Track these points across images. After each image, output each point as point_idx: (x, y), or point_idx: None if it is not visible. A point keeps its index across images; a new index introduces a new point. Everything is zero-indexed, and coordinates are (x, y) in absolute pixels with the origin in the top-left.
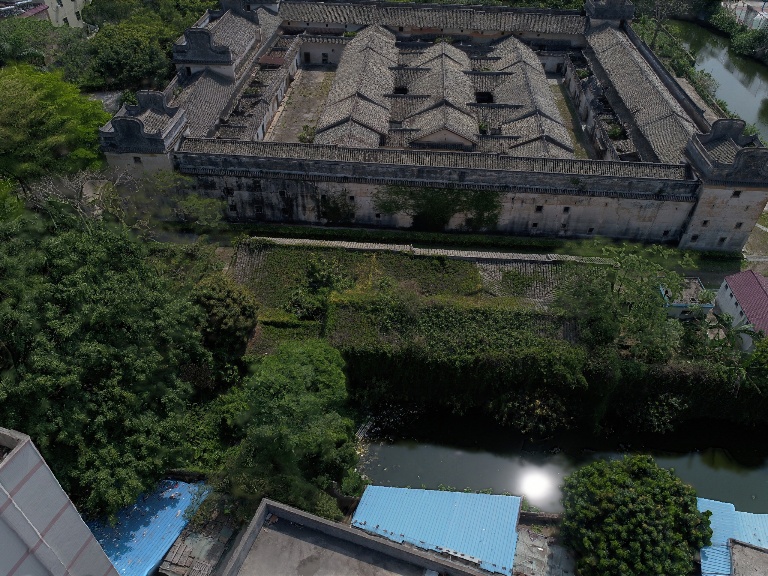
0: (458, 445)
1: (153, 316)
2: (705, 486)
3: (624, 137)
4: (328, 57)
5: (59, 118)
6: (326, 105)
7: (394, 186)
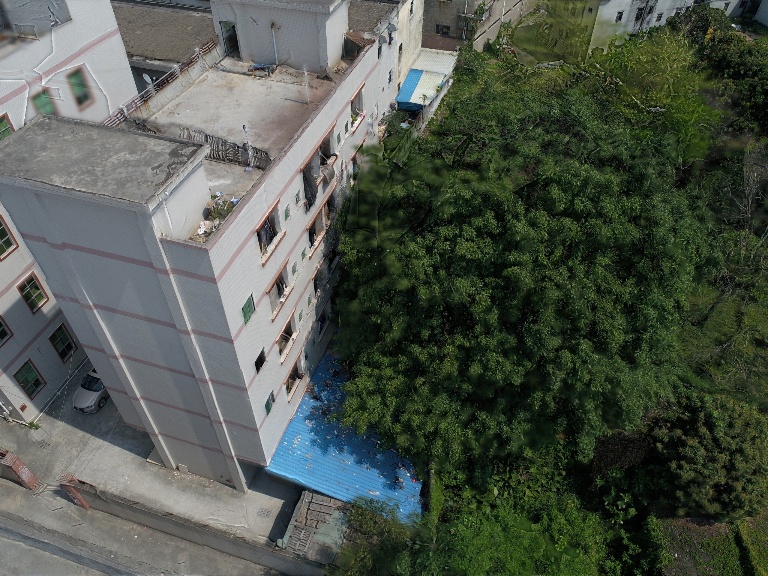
0: None
1: (574, 344)
2: None
3: None
4: None
5: None
6: None
7: None
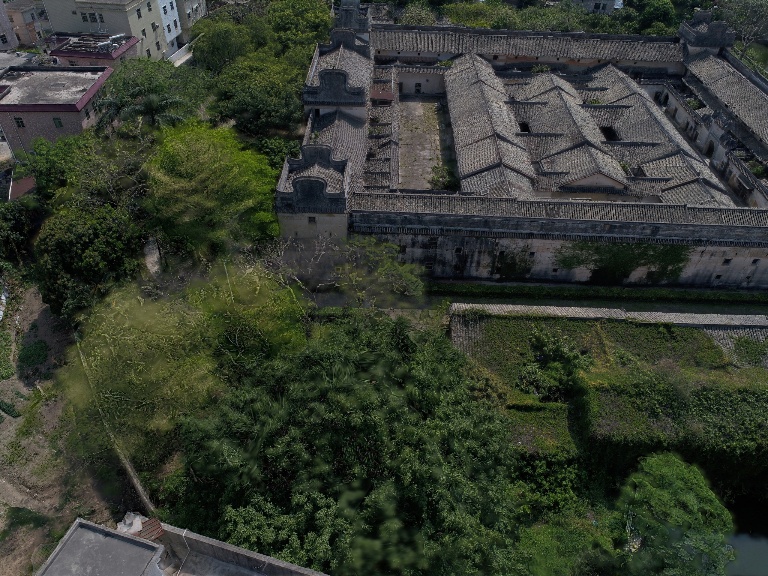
0: (733, 536)
1: (486, 433)
2: None
3: (767, 175)
4: (421, 87)
5: (242, 180)
6: (459, 146)
7: (580, 241)
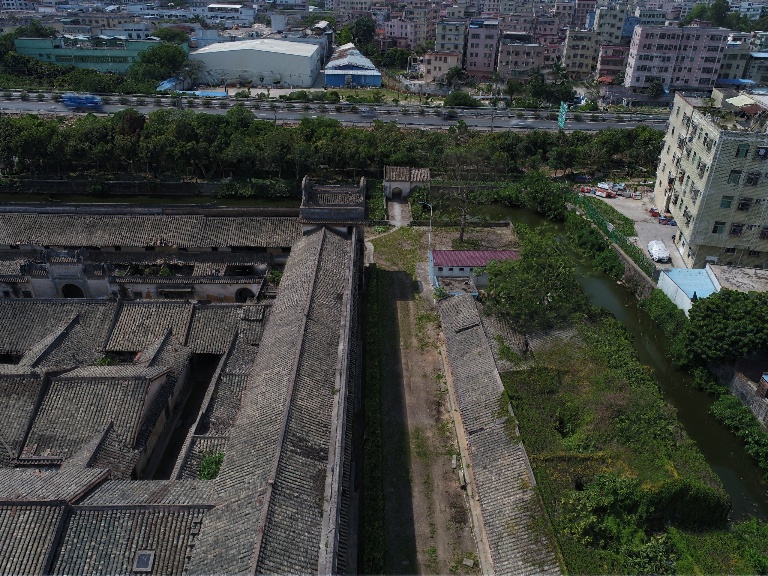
0: None
1: None
2: None
3: (175, 271)
4: None
5: None
6: None
7: None
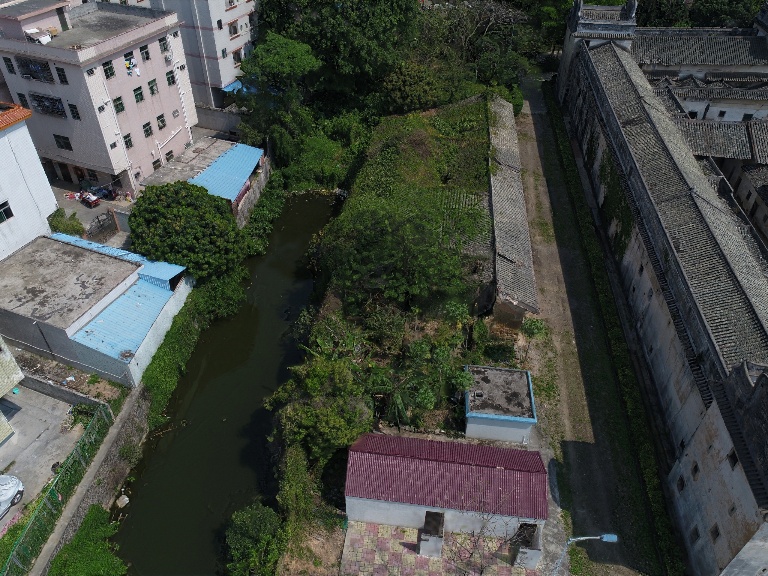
0: None
1: None
2: (249, 386)
3: None
4: None
5: None
6: None
7: None
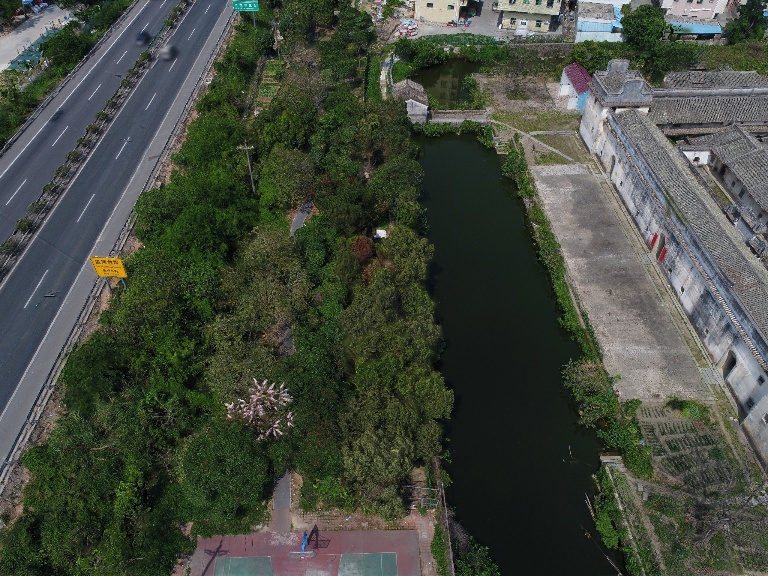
0: None
1: None
2: None
3: None
4: None
5: None
6: None
7: None
